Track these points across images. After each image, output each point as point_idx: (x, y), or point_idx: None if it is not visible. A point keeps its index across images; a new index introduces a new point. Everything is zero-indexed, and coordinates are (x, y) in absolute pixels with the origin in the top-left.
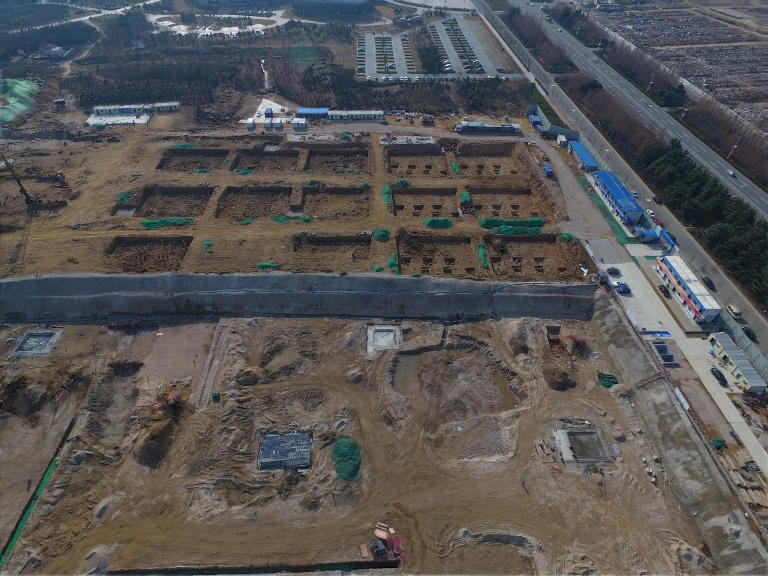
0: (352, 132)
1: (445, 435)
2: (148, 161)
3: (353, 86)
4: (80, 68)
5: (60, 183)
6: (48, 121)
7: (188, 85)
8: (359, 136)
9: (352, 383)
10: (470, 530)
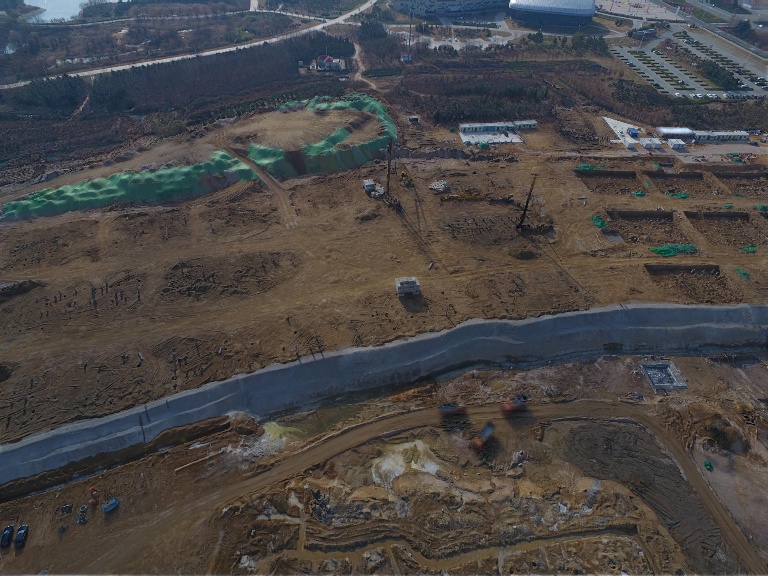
0: (738, 154)
1: None
2: (573, 183)
3: (673, 104)
4: (380, 82)
5: (516, 206)
6: (425, 139)
7: (511, 101)
8: (749, 158)
9: None
10: None
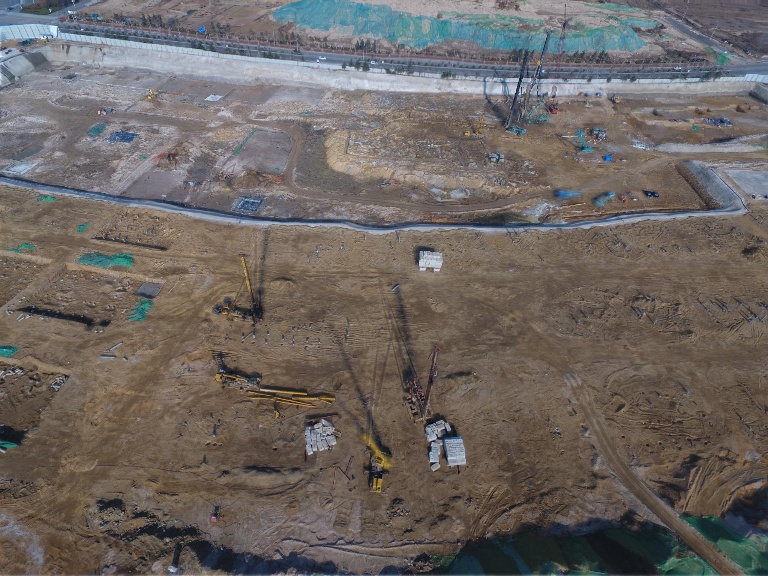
0: None
1: (42, 129)
2: (73, 400)
3: None
4: None
5: (223, 363)
6: None
7: None
8: None
9: (64, 151)
10: (69, 108)
